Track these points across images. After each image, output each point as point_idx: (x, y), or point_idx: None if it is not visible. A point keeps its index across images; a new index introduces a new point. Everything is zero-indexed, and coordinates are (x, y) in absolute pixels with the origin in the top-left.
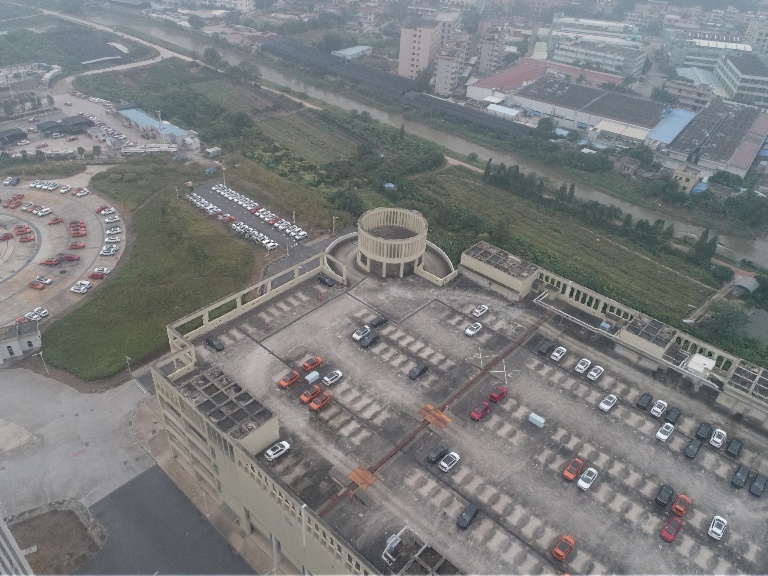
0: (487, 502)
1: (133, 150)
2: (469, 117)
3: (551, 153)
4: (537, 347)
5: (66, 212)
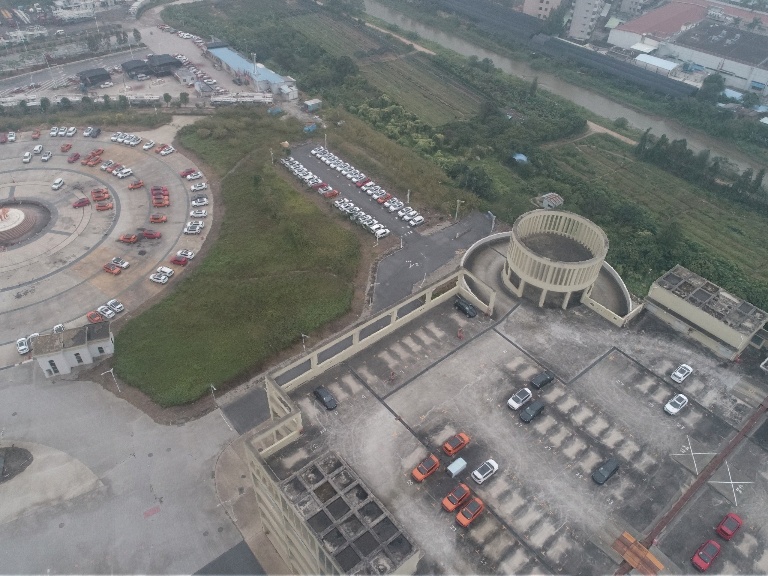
0: None
1: (224, 99)
2: (613, 70)
3: (721, 122)
4: None
5: (148, 174)
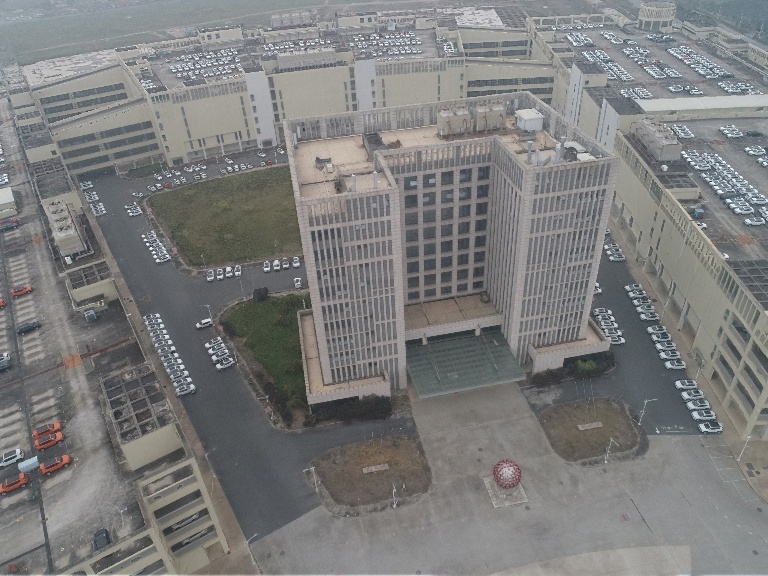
0: (5, 337)
1: None
2: None
3: None
4: None
5: None
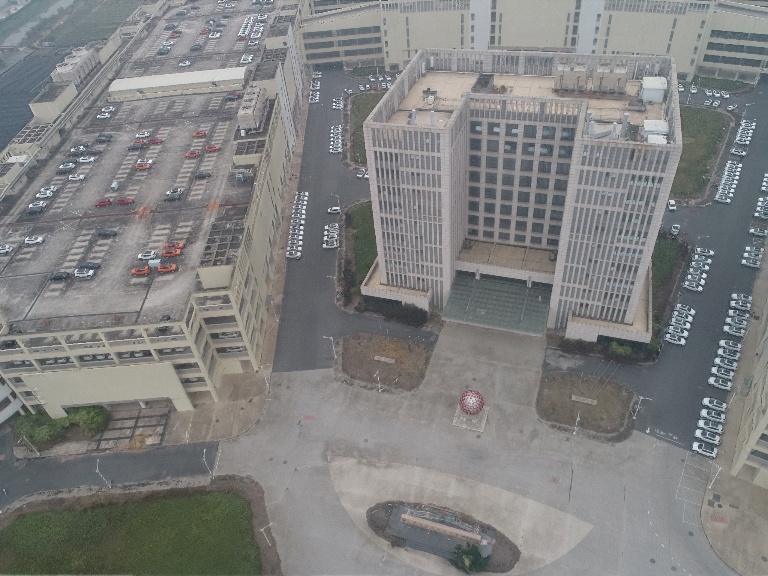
0: (188, 178)
1: None
2: None
3: None
4: (34, 217)
5: None
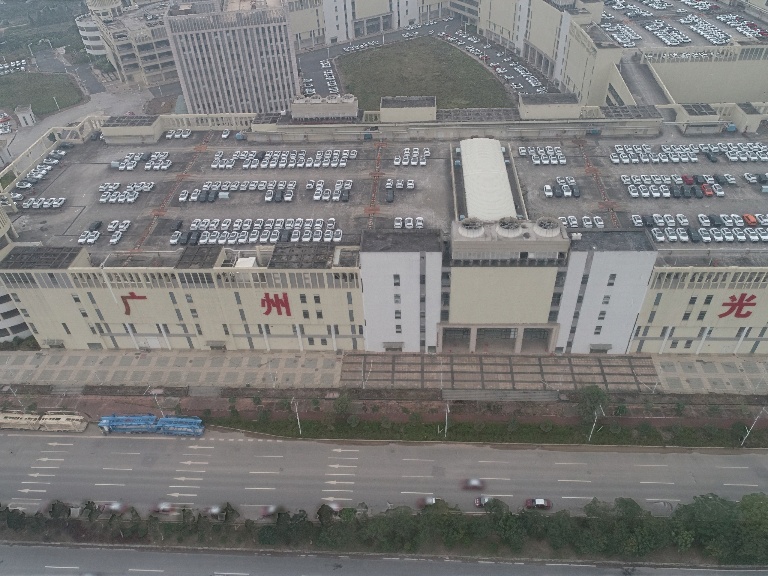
0: None
1: None
2: None
3: (37, 6)
4: None
5: None
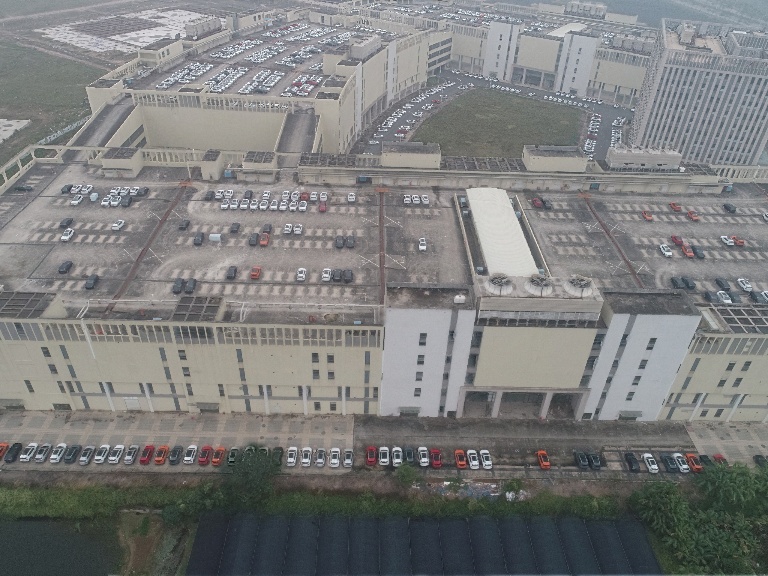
0: None
1: None
2: None
3: None
4: None
5: None
